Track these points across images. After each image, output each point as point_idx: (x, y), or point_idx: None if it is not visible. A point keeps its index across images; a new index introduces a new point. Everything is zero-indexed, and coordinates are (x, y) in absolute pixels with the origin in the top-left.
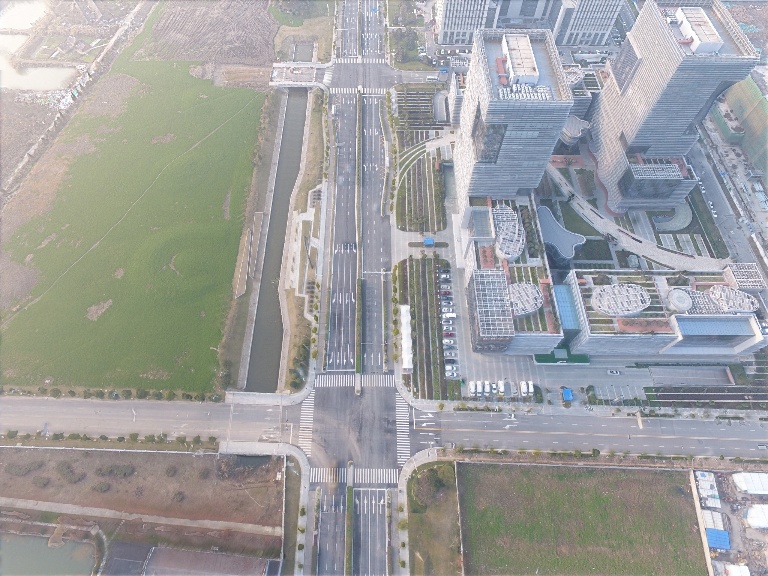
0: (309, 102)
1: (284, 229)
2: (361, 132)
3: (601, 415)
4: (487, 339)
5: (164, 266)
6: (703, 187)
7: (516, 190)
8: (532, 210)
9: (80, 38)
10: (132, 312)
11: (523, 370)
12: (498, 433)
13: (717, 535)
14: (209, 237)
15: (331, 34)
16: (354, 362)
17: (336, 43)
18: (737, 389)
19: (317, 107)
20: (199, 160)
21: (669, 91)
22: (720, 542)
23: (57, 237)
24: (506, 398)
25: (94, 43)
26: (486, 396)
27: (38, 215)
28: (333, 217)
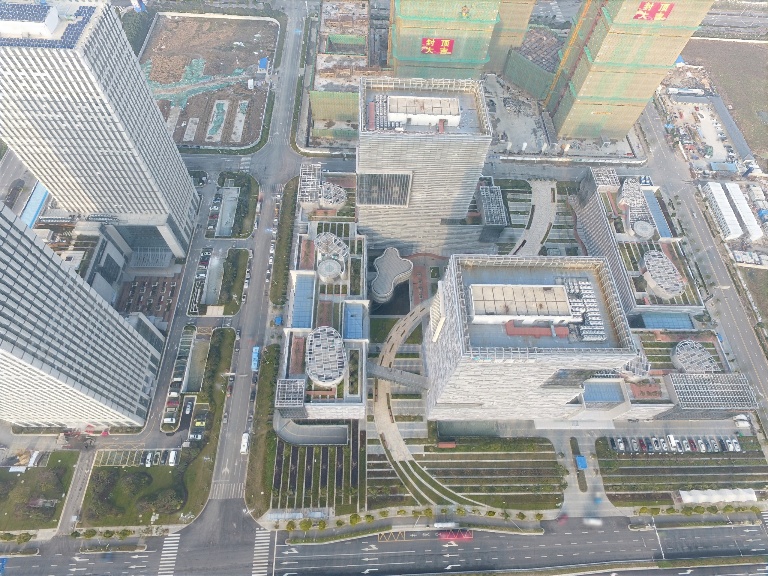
0: None
1: None
2: None
3: (717, 315)
4: None
5: None
6: None
7: None
8: None
9: None
10: None
11: None
12: None
13: None
14: None
15: None
16: (767, 565)
17: None
18: None
19: None
20: None
21: None
22: None
23: None
24: None
25: None
26: None
27: None
28: None
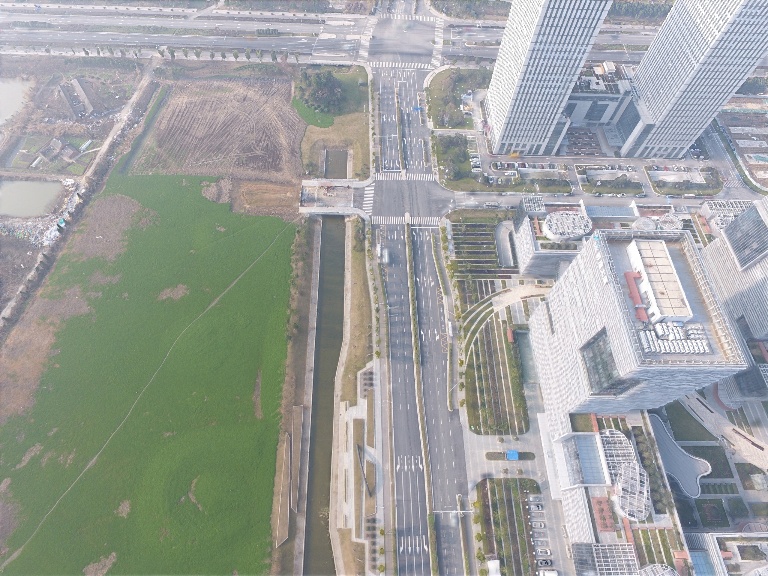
0: (348, 235)
1: (330, 429)
2: (414, 282)
3: None
4: None
5: (182, 497)
6: None
7: (629, 409)
8: (648, 434)
9: (67, 141)
10: (143, 574)
11: None
12: None
13: None
14: (238, 449)
15: (367, 138)
16: None
17: (374, 151)
18: None
19: (358, 244)
20: (220, 326)
21: None
22: None
23: (42, 449)
24: None
25: (84, 147)
26: None
27: (17, 414)
28: (390, 413)
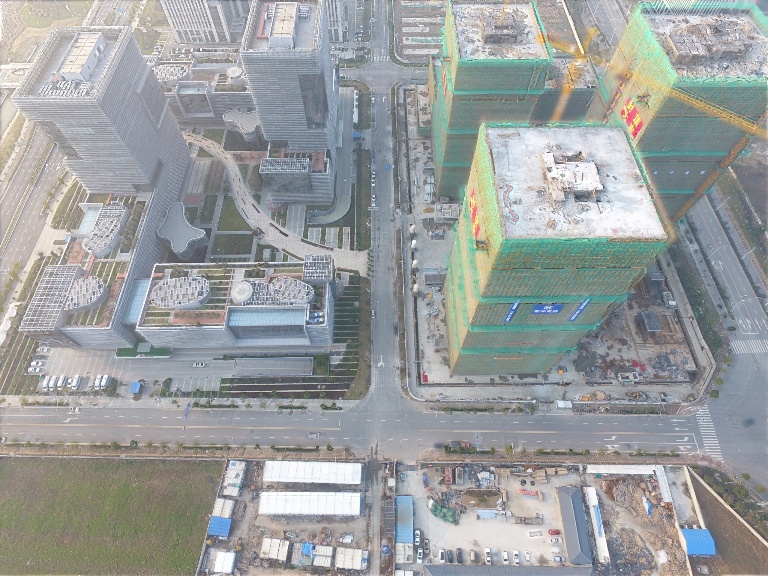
0: None
1: None
2: None
3: (166, 407)
4: (28, 334)
5: None
6: (373, 180)
7: (131, 186)
8: (147, 206)
9: None
10: None
11: (109, 364)
12: (55, 427)
13: (219, 523)
14: None
15: None
16: None
17: None
18: (312, 379)
19: None
20: None
21: (255, 86)
22: (220, 530)
23: None
24: (76, 392)
25: None
26: (59, 390)
27: None
28: None
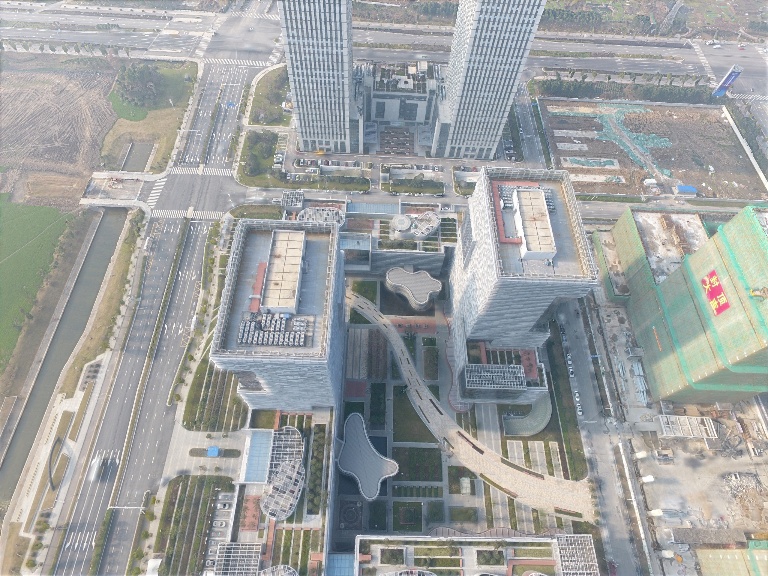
0: (124, 228)
1: (40, 421)
2: (175, 275)
3: None
4: None
5: None
6: (571, 370)
7: (310, 406)
8: (329, 432)
9: None
10: None
11: None
12: None
13: None
14: None
15: None
16: None
17: (179, 145)
18: None
19: (130, 237)
20: None
21: (493, 302)
22: None
23: None
24: None
25: None
26: None
27: None
28: (104, 406)
